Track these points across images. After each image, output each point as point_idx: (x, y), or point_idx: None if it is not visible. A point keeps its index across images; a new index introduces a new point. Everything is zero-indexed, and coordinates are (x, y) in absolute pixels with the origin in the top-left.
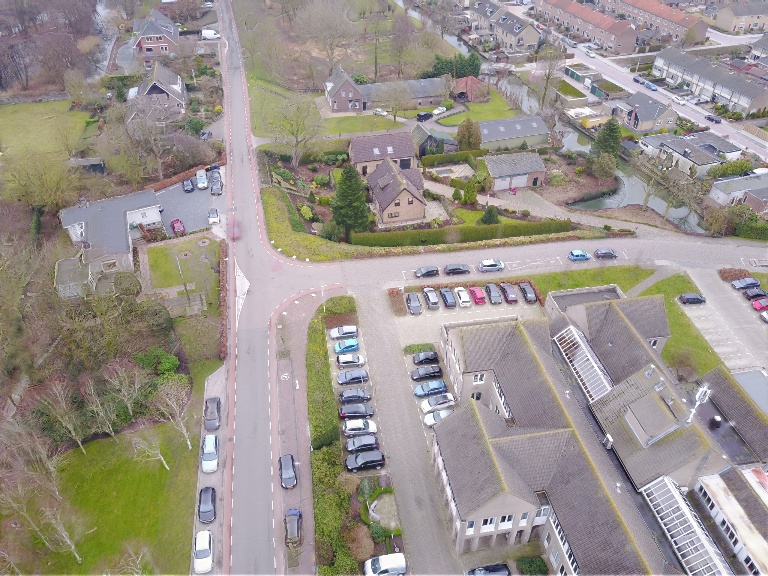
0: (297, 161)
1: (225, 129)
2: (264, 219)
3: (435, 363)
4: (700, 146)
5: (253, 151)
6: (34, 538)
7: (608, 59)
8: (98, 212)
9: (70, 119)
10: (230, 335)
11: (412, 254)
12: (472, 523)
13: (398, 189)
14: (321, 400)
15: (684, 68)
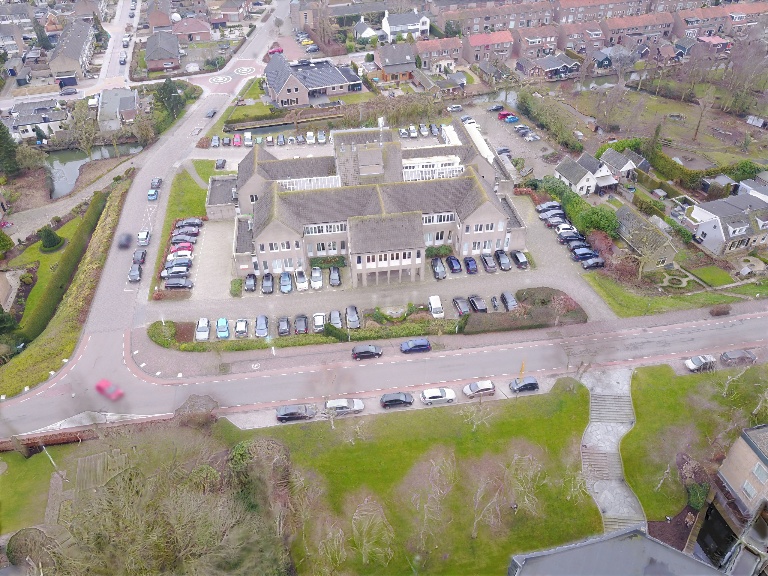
0: None
1: None
2: None
3: (256, 280)
4: None
5: None
6: (410, 575)
7: None
8: None
9: None
10: None
11: (97, 283)
12: None
13: None
14: None
15: None
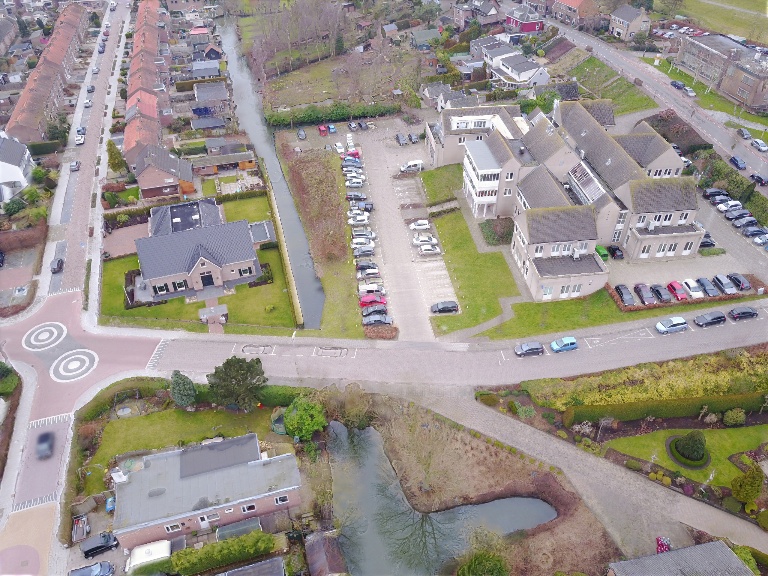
0: None
1: None
2: None
3: None
4: None
5: None
6: None
7: None
8: None
9: None
10: None
11: None
12: None
13: None
14: None
15: None
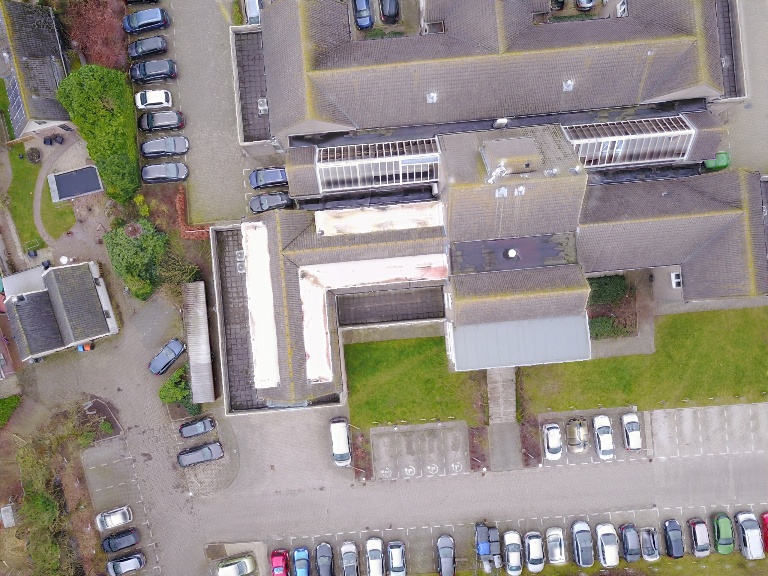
0: None
1: None
2: None
3: None
4: None
5: None
6: None
7: None
8: None
9: None
10: None
11: None
12: None
13: None
14: None
15: None
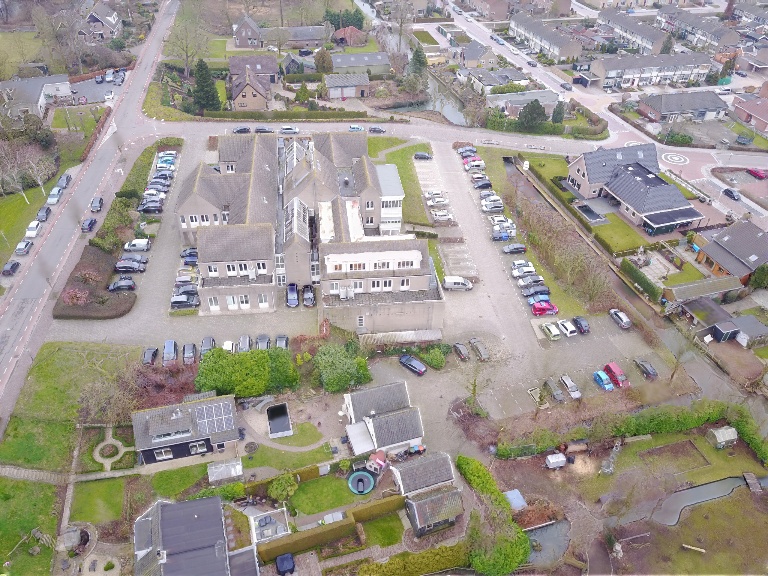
0: (188, 72)
1: (142, 50)
2: (144, 99)
3: None
4: (499, 76)
5: (156, 63)
6: None
7: (481, 23)
8: (24, 83)
9: (33, 43)
10: (92, 151)
11: (238, 122)
12: (184, 219)
13: (244, 84)
14: (135, 181)
15: (525, 27)
